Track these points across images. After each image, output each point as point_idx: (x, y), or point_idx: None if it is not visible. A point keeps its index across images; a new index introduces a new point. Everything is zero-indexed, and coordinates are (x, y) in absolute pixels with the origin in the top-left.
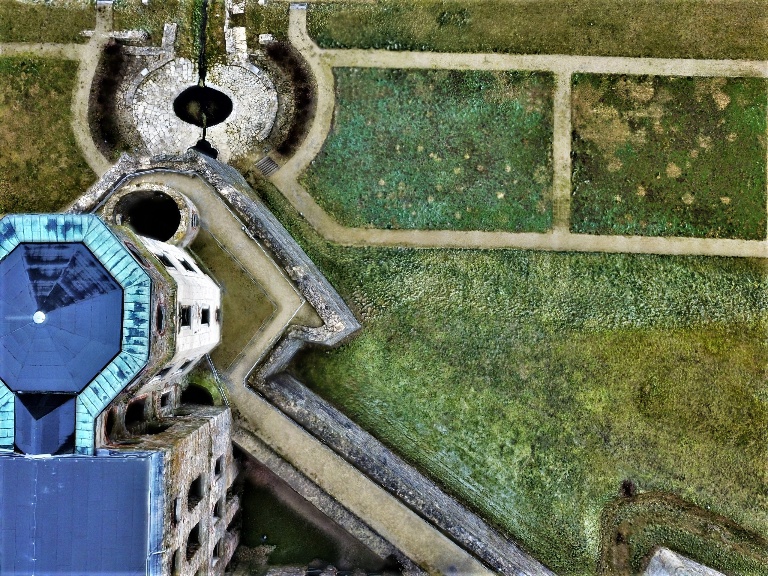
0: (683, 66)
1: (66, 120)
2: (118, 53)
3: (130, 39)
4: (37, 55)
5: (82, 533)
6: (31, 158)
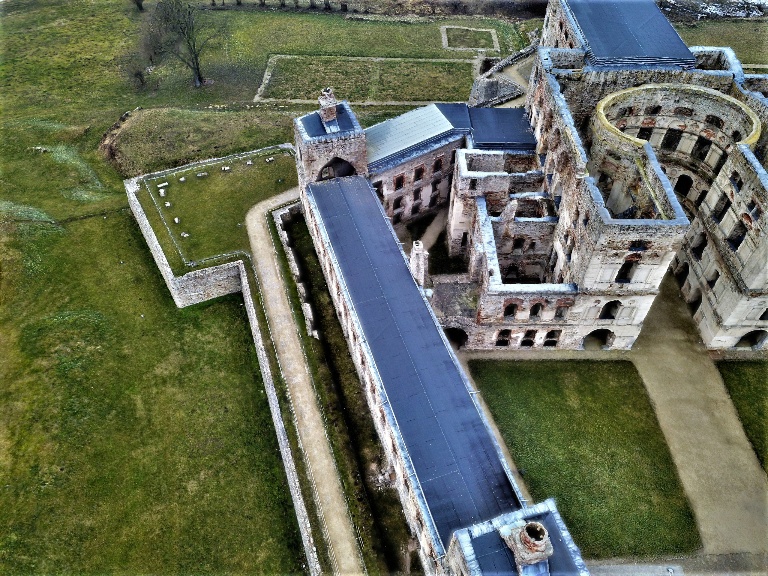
0: (764, 66)
1: (470, 77)
2: (489, 64)
3: (494, 61)
4: (452, 62)
5: (632, 4)
6: (454, 86)
